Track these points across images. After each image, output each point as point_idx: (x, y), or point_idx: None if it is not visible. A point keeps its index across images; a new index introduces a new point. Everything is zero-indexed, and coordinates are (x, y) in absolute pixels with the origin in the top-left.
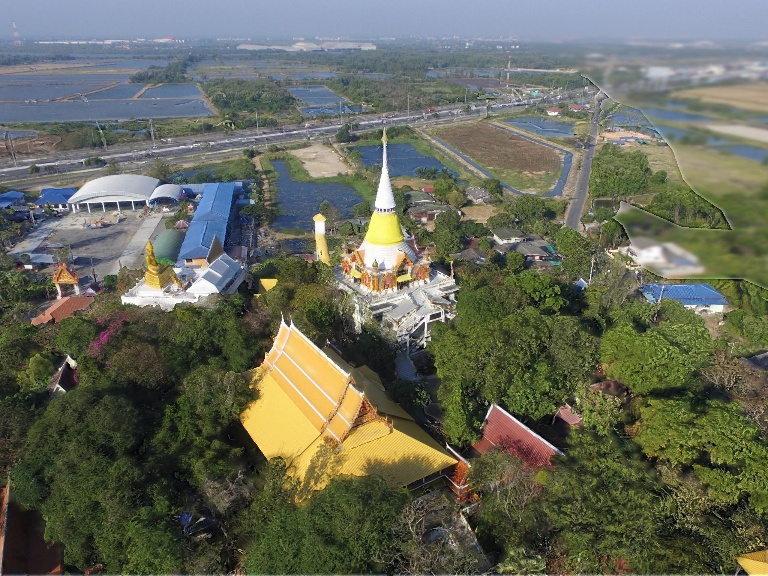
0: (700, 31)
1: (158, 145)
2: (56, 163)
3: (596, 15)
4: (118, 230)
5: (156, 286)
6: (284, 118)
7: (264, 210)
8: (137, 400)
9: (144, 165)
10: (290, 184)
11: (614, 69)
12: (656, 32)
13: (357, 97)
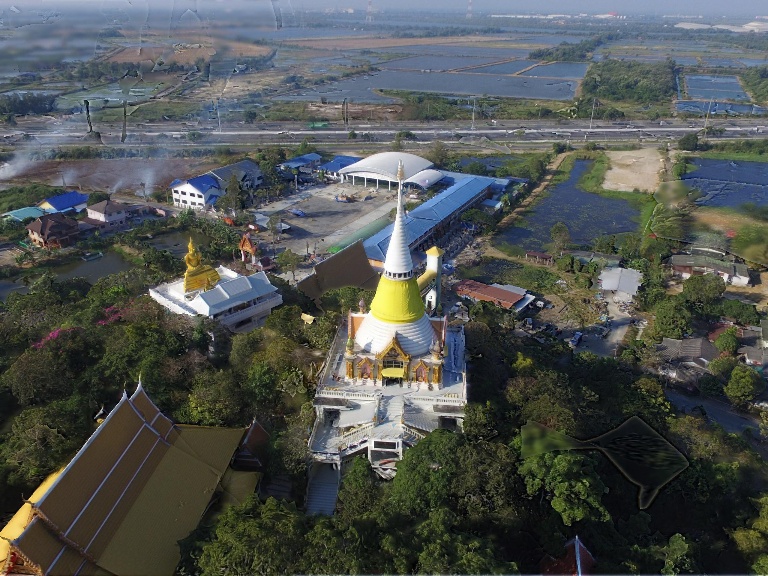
0: None
1: (482, 126)
2: (363, 132)
3: None
4: (356, 208)
5: (184, 288)
6: (637, 112)
7: (486, 218)
8: (7, 411)
9: (424, 146)
10: (568, 191)
11: None
12: None
13: (764, 94)
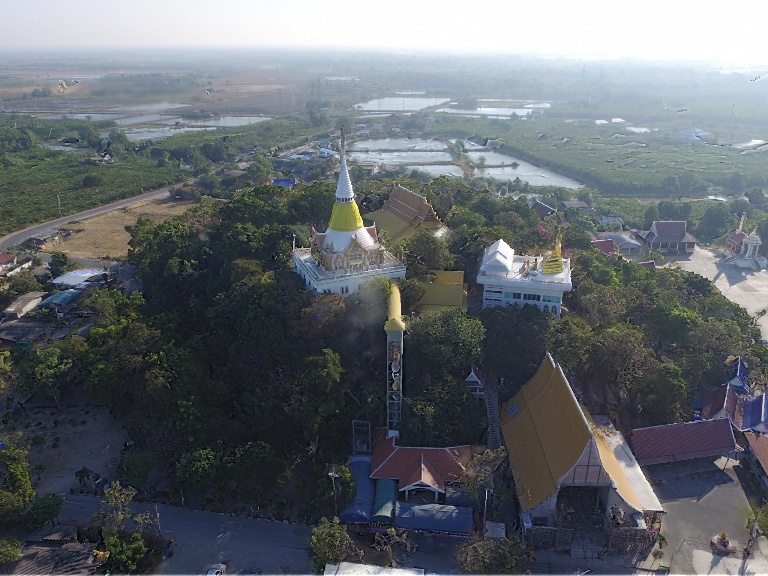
0: (335, 40)
1: None
2: None
3: (355, 37)
4: None
5: None
6: None
7: None
8: None
9: None
10: None
11: (350, 48)
12: (343, 40)
13: None
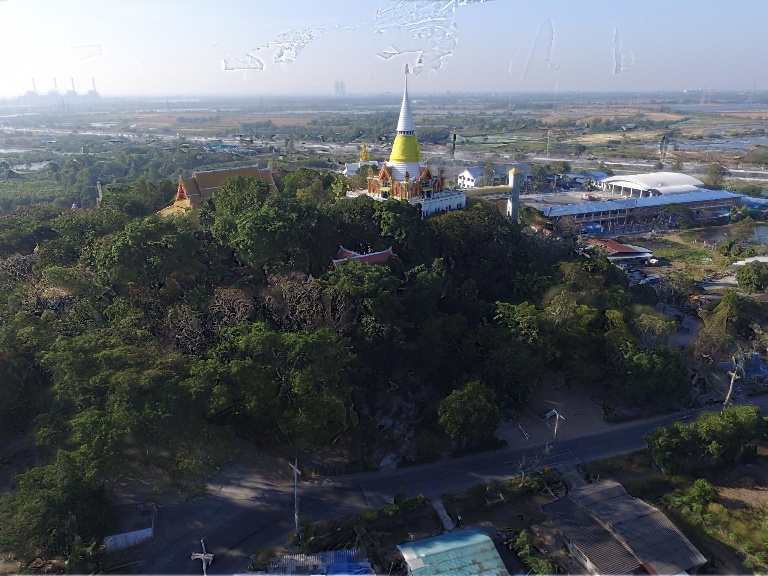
0: None
1: None
2: None
3: None
4: None
5: None
6: None
7: (680, 210)
8: None
9: (701, 168)
10: None
11: None
12: None
13: None
